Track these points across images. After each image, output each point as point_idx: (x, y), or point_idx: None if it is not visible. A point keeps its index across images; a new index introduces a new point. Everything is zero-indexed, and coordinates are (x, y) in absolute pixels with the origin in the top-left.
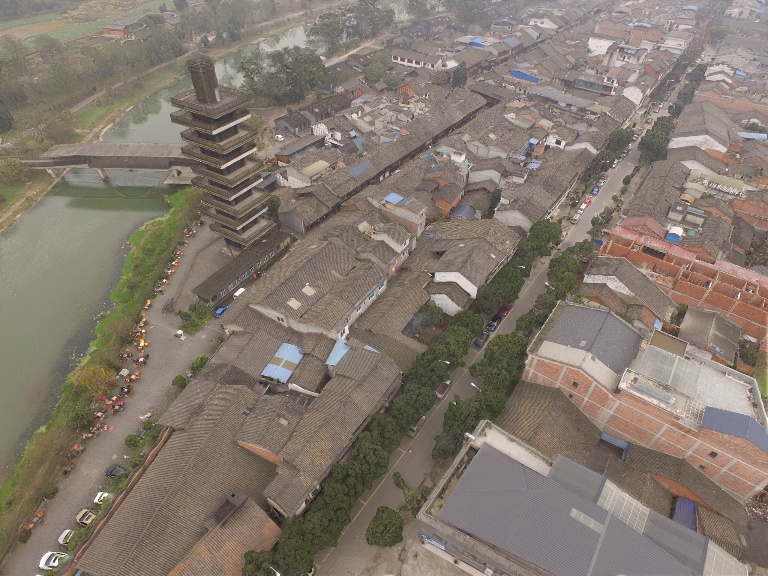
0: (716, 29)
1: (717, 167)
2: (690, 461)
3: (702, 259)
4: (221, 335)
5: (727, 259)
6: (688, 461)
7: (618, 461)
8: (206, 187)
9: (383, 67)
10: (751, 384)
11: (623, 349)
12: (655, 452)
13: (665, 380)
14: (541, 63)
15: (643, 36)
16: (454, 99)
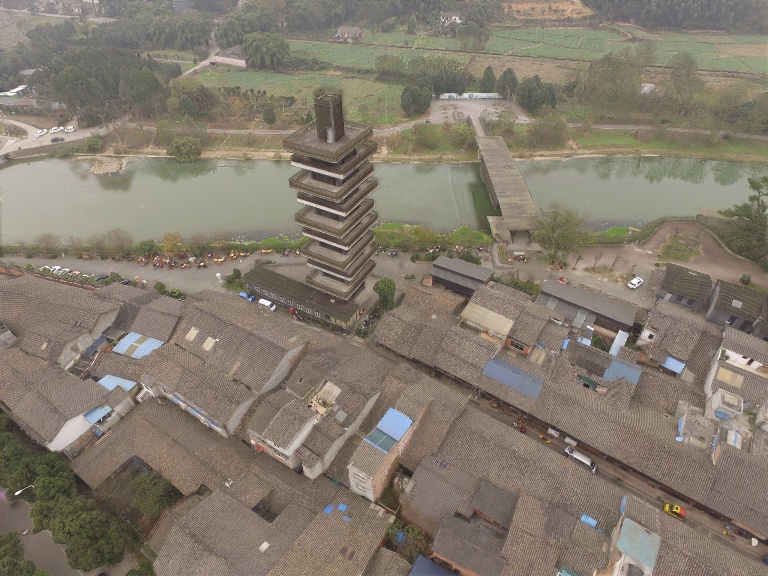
0: None
1: None
2: None
3: None
4: None
5: None
6: None
7: None
8: None
9: None
10: None
11: None
12: None
13: None
14: None
15: None
16: None
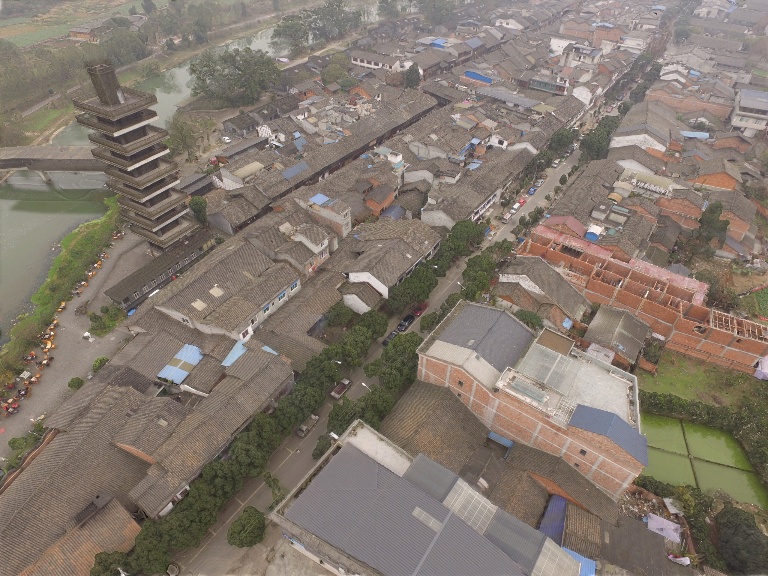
0: (680, 29)
1: (655, 166)
2: (566, 459)
3: (619, 258)
4: (130, 337)
5: (648, 257)
6: (564, 459)
7: (499, 460)
8: (120, 189)
9: (340, 68)
10: (632, 382)
11: (512, 348)
12: (535, 450)
13: (542, 378)
14: (499, 64)
15: (606, 36)
16: (404, 100)
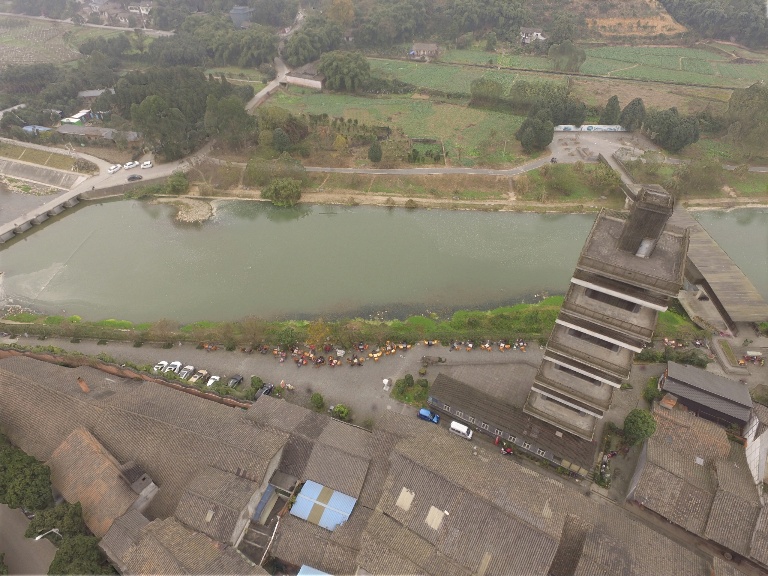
0: None
1: None
2: None
3: None
4: None
5: None
6: None
7: None
8: None
9: None
10: None
11: None
12: None
13: None
14: None
15: None
16: None
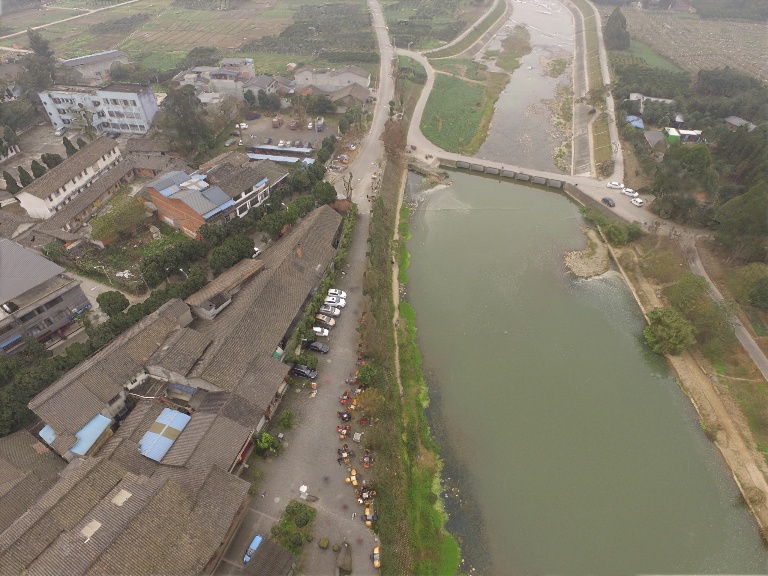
0: None
1: None
2: None
3: None
4: (253, 504)
5: None
6: None
7: None
8: None
9: None
10: None
11: None
12: None
13: None
14: None
15: None
16: None
